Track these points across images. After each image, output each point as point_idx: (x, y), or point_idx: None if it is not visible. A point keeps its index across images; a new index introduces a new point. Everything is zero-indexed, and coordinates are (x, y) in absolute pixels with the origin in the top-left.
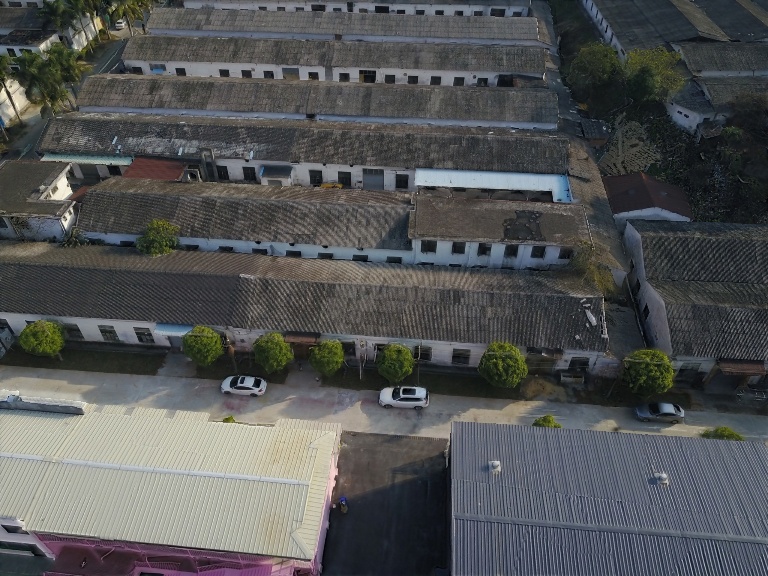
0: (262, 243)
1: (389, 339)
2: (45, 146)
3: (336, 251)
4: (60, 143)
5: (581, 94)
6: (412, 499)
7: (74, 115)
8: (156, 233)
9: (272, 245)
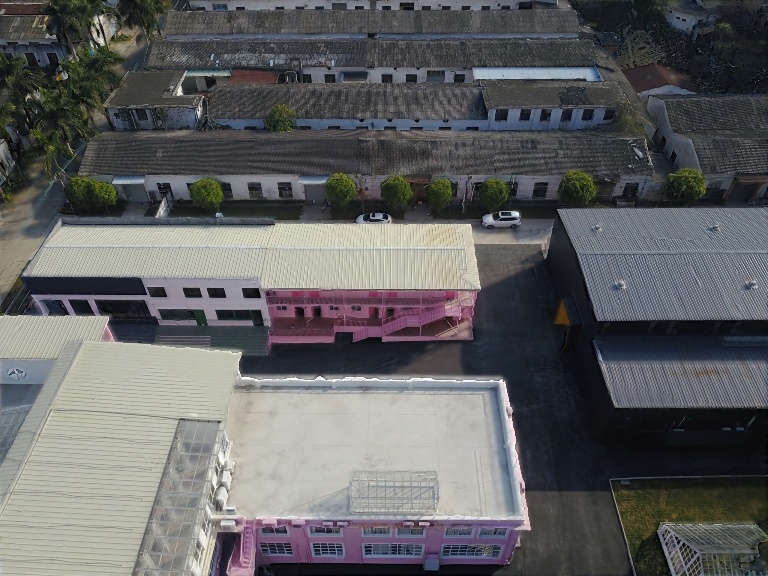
0: (365, 121)
1: (486, 176)
2: (152, 64)
3: (425, 125)
4: (164, 61)
5: (590, 15)
6: (525, 278)
7: None
8: (279, 115)
9: (373, 122)
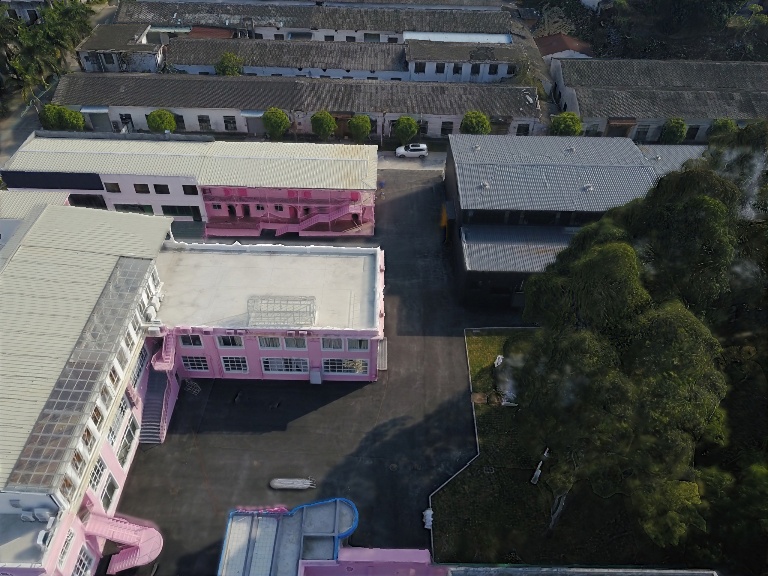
0: (303, 70)
1: (400, 114)
2: (121, 20)
3: (355, 75)
4: (132, 18)
5: None
6: (424, 194)
7: (136, 1)
8: (228, 62)
9: (310, 71)
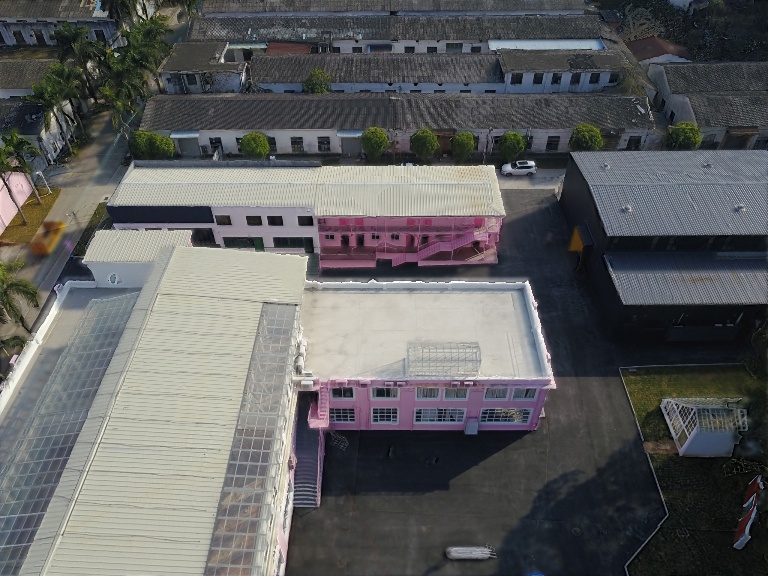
0: (393, 85)
1: (505, 130)
2: (194, 37)
3: (448, 88)
4: (206, 35)
5: None
6: (541, 215)
7: None
8: (316, 79)
9: (400, 86)
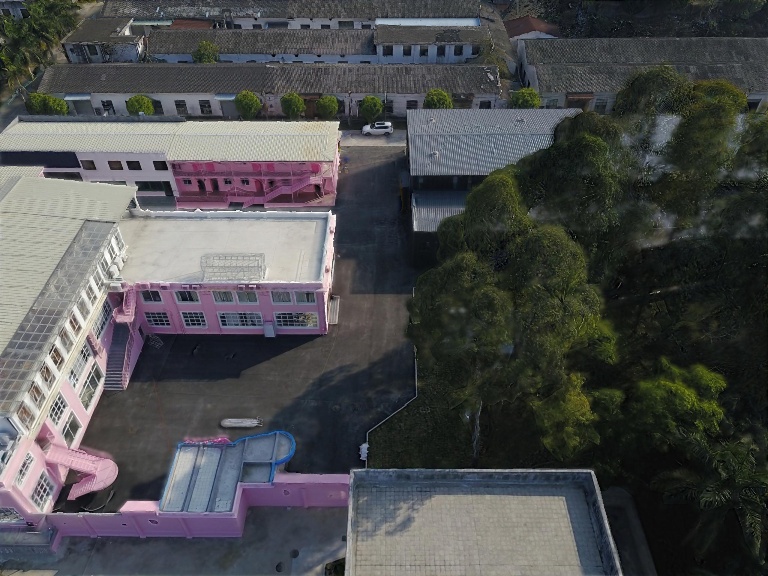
0: (276, 56)
1: (366, 94)
2: (107, 15)
3: (326, 59)
4: (117, 13)
5: None
6: (386, 168)
7: None
8: (205, 50)
9: (283, 57)
